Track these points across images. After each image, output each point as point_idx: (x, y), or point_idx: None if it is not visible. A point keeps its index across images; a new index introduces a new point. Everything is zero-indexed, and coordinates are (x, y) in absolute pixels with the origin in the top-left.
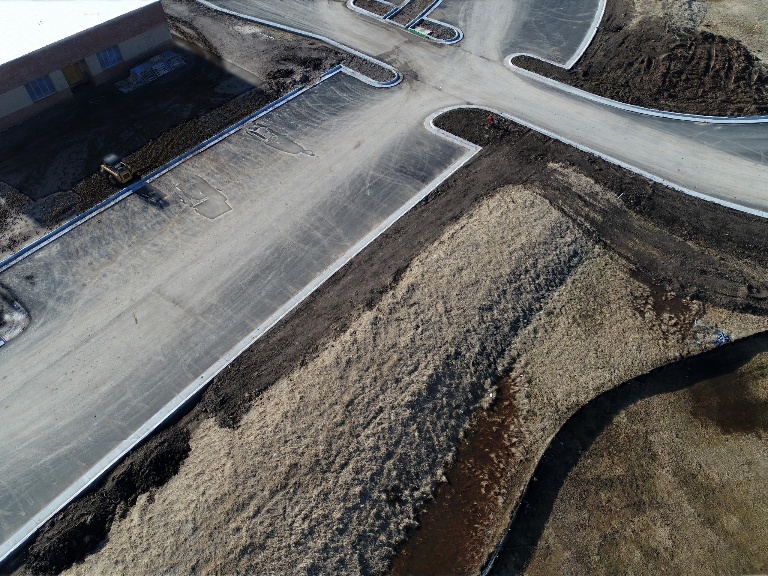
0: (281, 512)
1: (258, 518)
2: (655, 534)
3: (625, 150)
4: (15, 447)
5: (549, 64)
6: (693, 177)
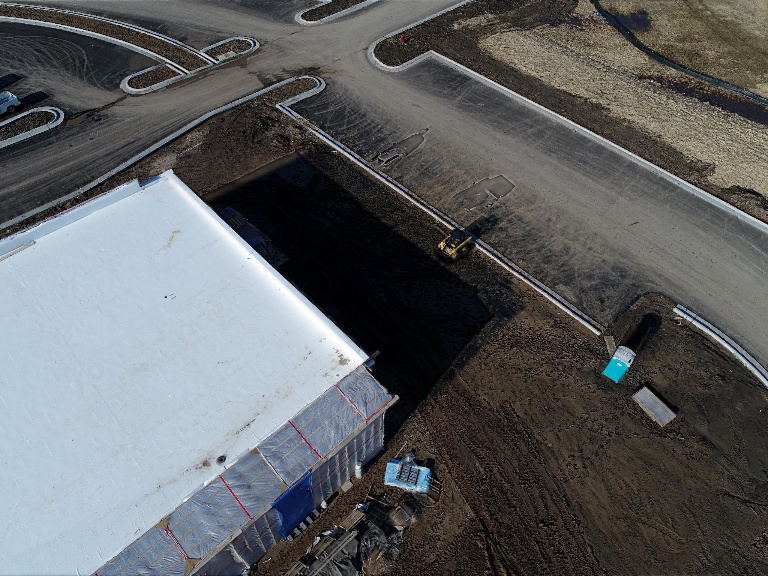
0: (760, 146)
1: (767, 154)
2: (711, 54)
3: (439, 3)
4: (765, 275)
5: (322, 7)
6: None
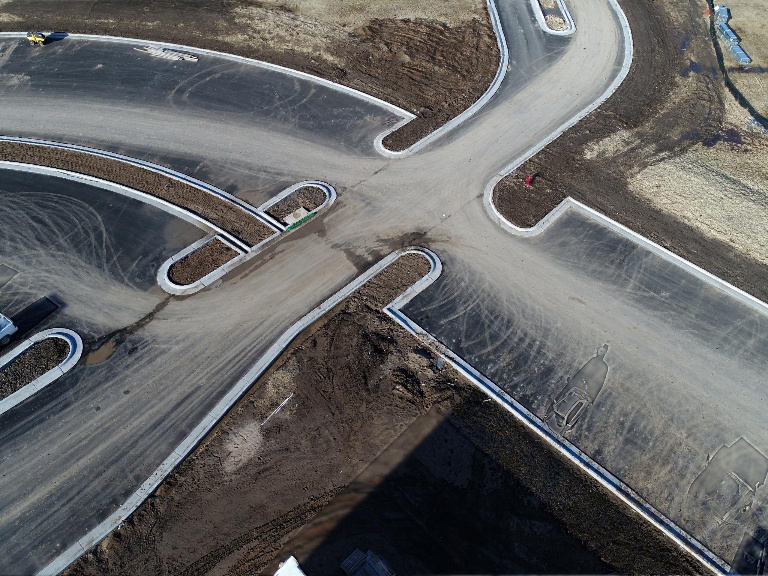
0: None
1: None
2: None
3: (553, 113)
4: None
5: (405, 127)
6: (585, 90)
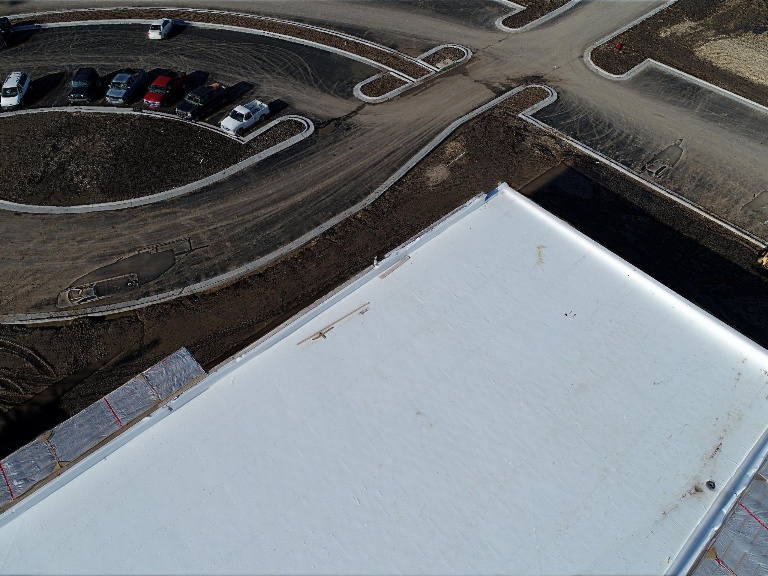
0: None
1: None
2: None
3: (633, 9)
4: None
5: (518, 14)
6: None
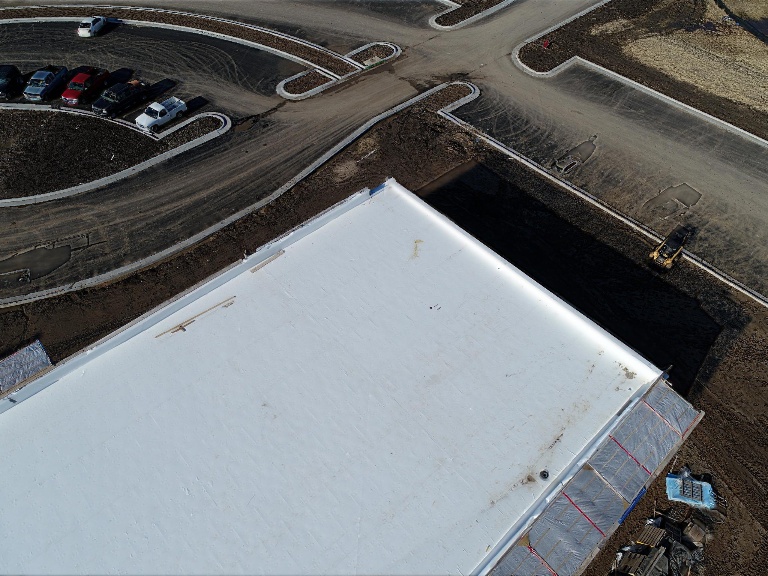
0: None
1: None
2: None
3: (569, 8)
4: None
5: (453, 11)
6: None
